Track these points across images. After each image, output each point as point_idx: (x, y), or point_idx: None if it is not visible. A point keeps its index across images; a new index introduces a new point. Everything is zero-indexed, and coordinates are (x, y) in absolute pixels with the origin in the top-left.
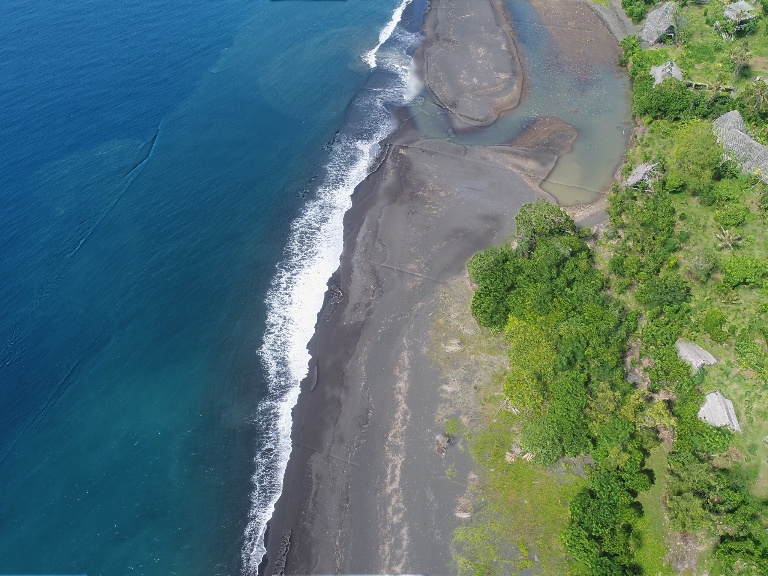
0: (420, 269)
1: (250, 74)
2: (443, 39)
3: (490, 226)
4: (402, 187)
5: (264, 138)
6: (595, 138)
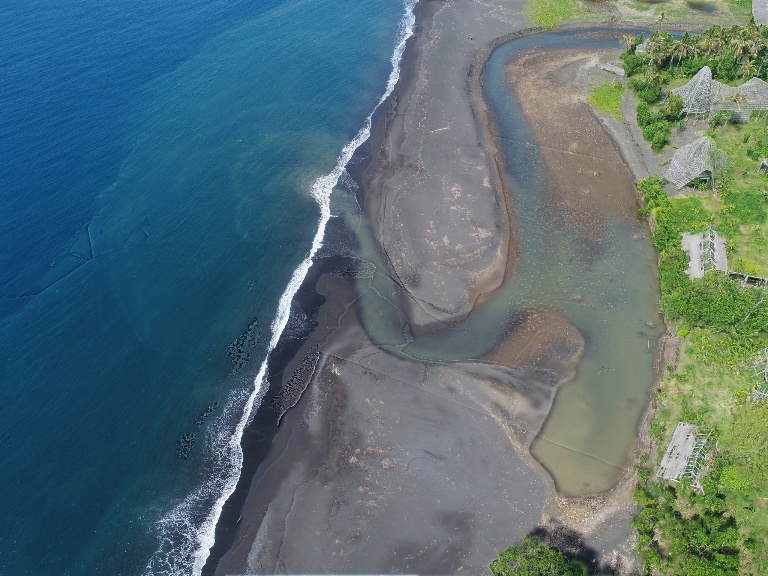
0: None
1: (122, 255)
2: (408, 165)
3: (453, 540)
4: (328, 444)
5: (139, 348)
6: (609, 353)
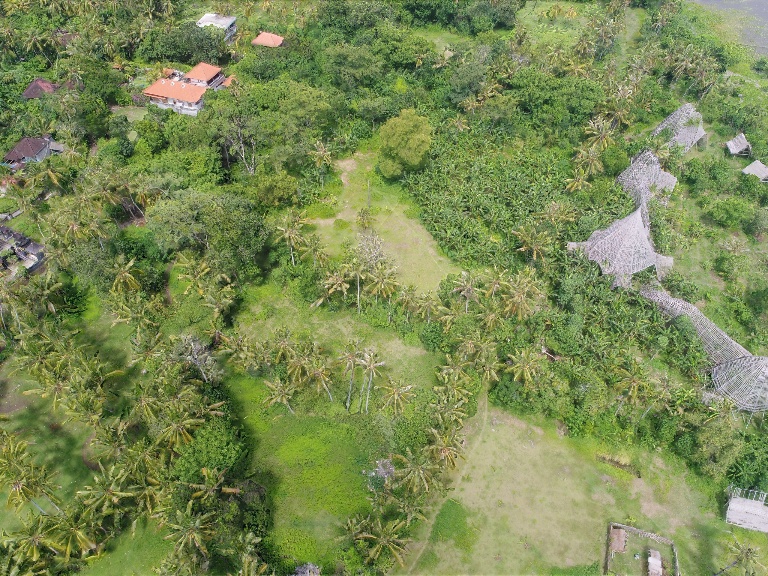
0: None
1: None
2: None
3: None
4: None
5: None
6: None
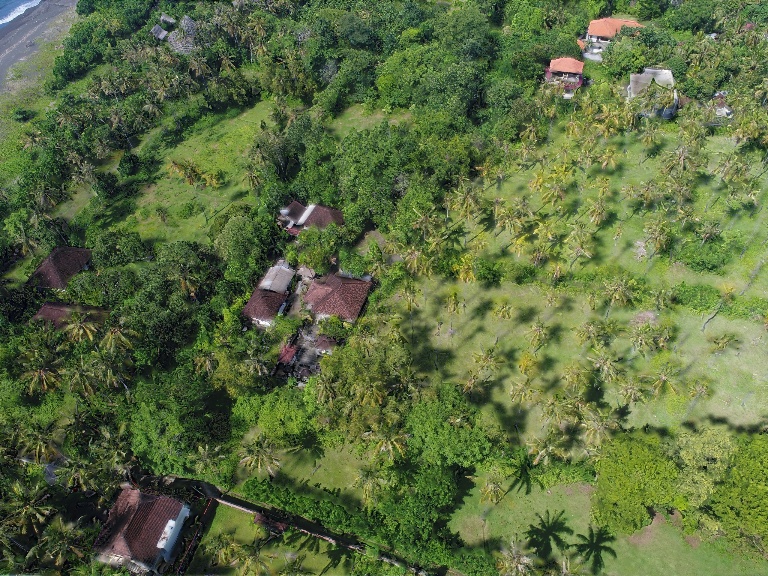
0: (72, 4)
1: None
2: None
3: None
4: None
5: None
6: None
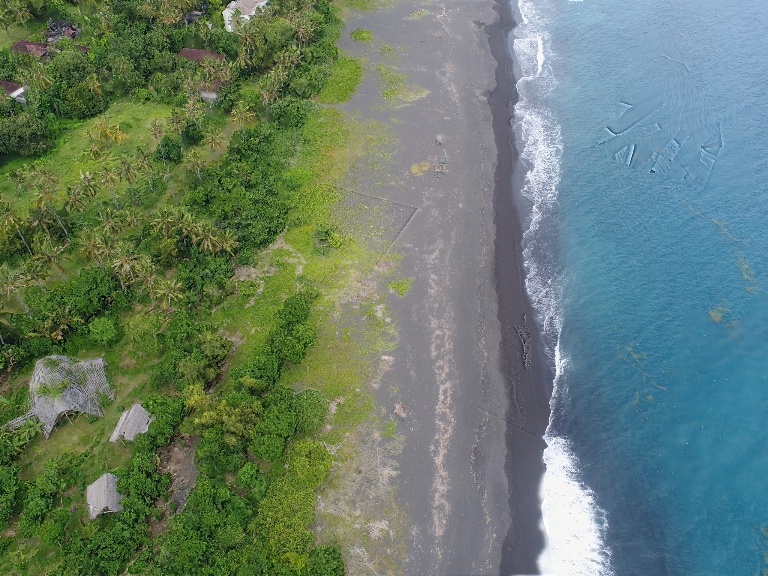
0: None
1: None
2: None
3: None
4: None
5: None
6: None
